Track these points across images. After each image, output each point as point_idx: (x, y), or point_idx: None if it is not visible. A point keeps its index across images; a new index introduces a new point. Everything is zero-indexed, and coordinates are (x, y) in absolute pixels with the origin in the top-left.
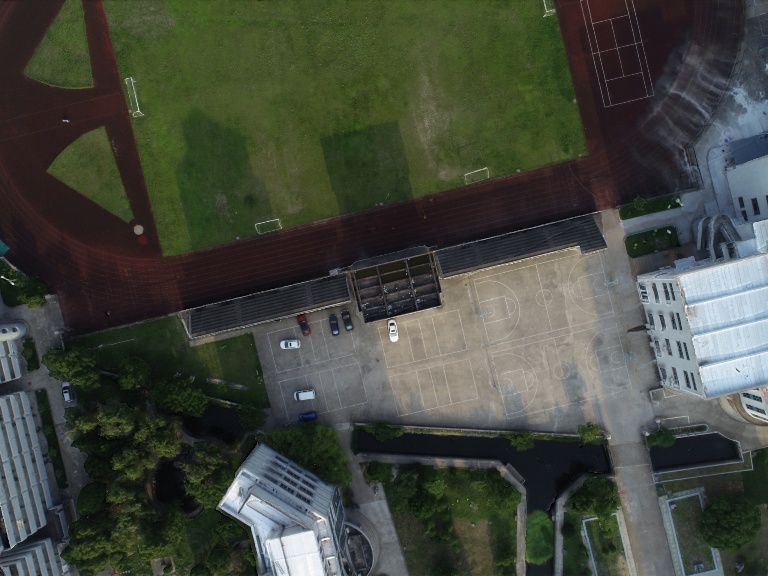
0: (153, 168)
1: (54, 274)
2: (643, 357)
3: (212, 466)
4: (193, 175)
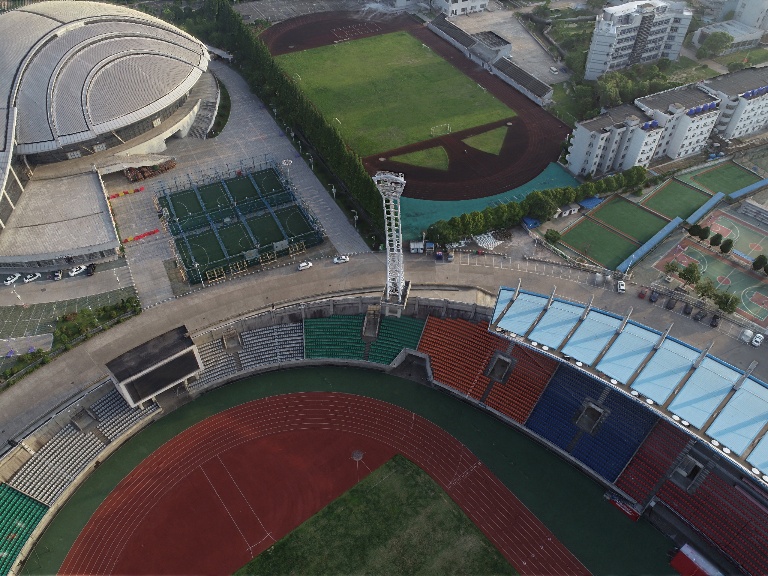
0: (474, 123)
1: (553, 145)
2: (478, 14)
3: (606, 75)
4: (470, 112)
